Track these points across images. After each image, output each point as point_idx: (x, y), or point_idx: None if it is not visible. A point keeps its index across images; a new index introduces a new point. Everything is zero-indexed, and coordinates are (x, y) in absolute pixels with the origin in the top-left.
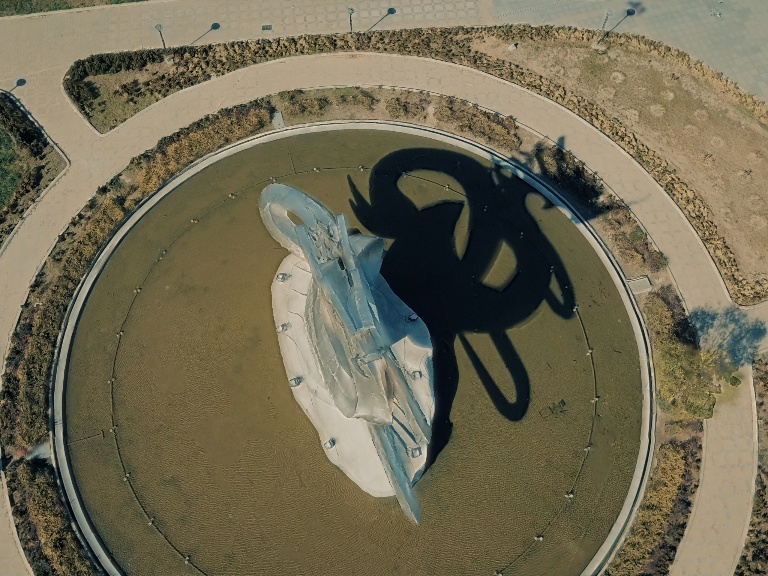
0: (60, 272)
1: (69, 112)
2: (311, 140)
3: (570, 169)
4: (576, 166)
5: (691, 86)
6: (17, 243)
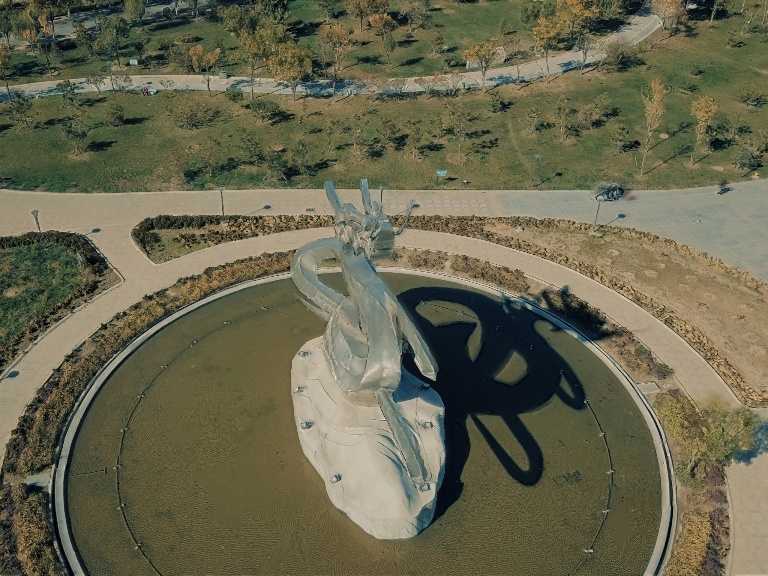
0: (96, 348)
1: (132, 250)
2: (340, 277)
3: (574, 303)
4: (580, 302)
5: (680, 261)
6: (62, 328)
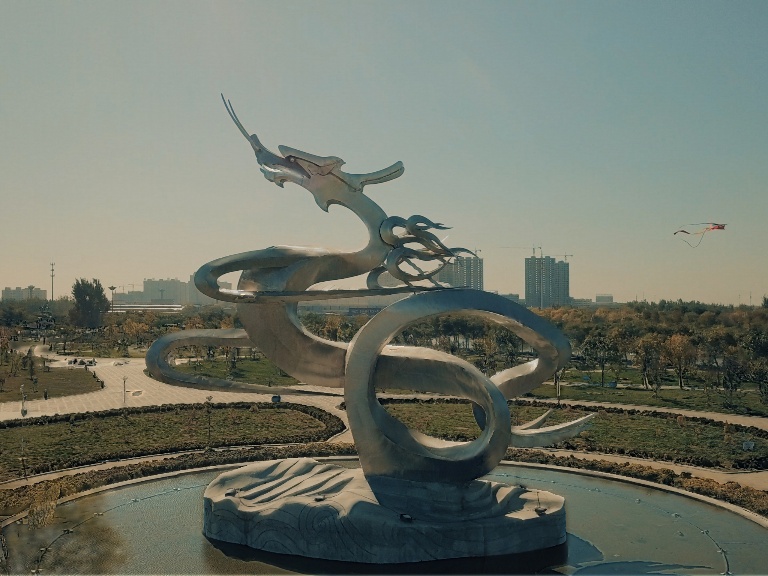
0: None
1: None
2: None
3: None
4: None
5: None
6: None
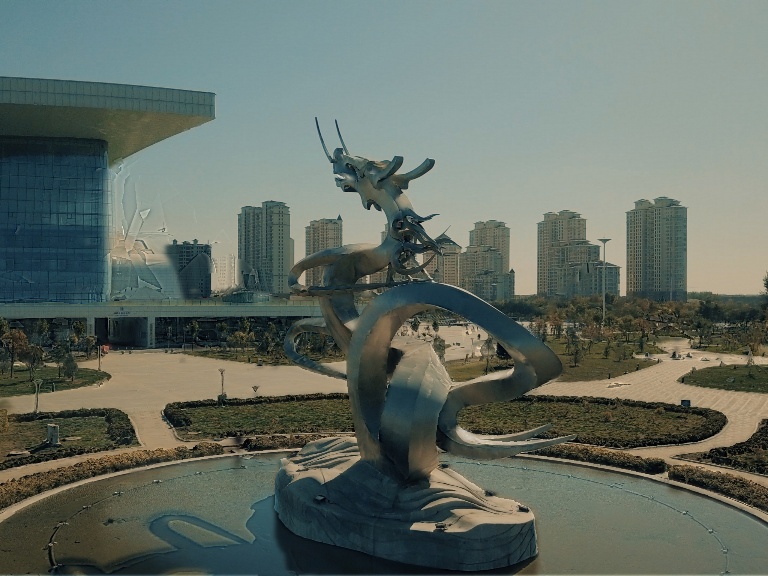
0: None
1: None
2: None
3: None
4: None
5: None
6: None
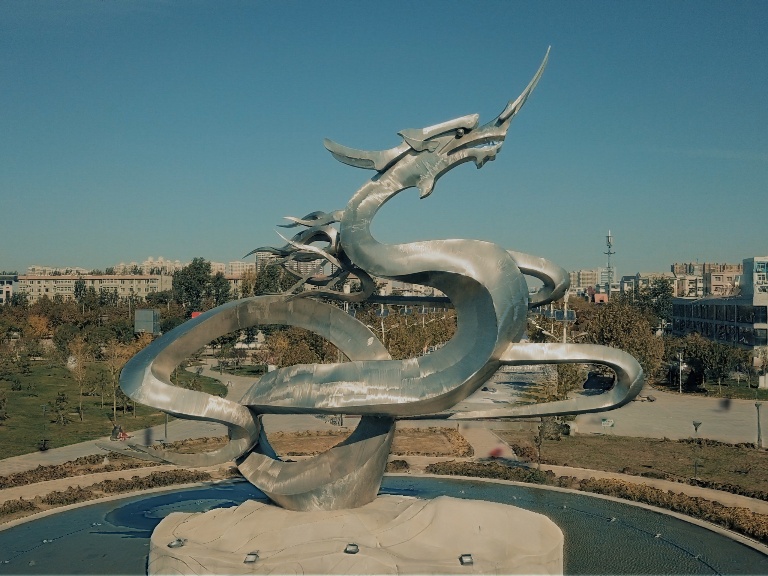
0: None
1: None
2: (1, 538)
3: None
4: None
5: None
6: None
